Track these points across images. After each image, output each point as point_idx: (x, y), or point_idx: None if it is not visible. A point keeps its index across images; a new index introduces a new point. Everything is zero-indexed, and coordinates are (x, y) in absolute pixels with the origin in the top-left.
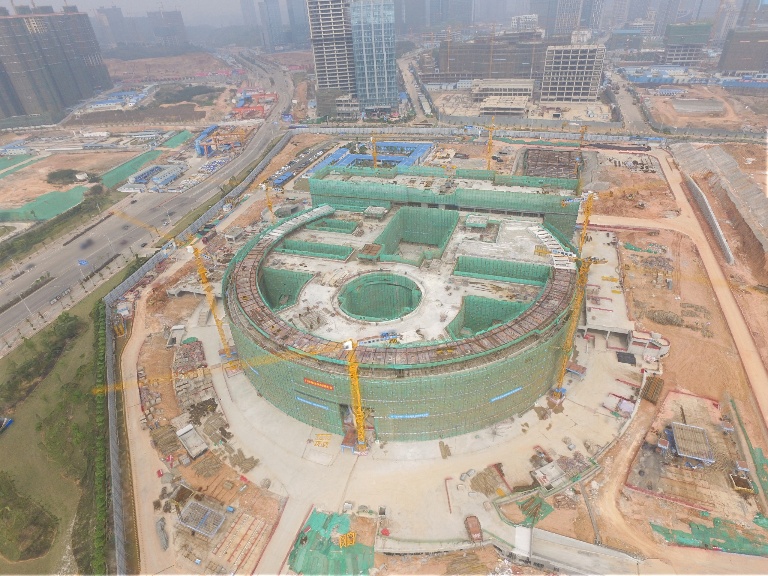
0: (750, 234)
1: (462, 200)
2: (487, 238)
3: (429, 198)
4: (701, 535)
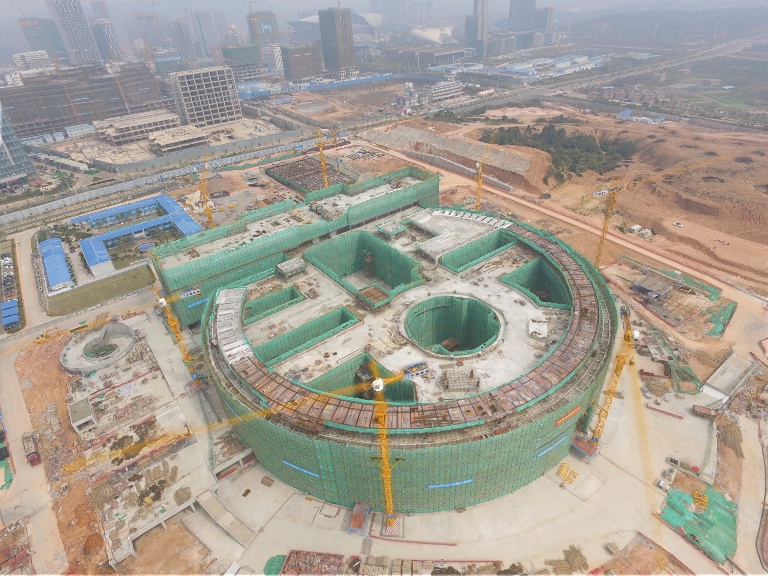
0: (499, 170)
1: (355, 217)
2: (416, 237)
3: (322, 229)
4: (717, 322)
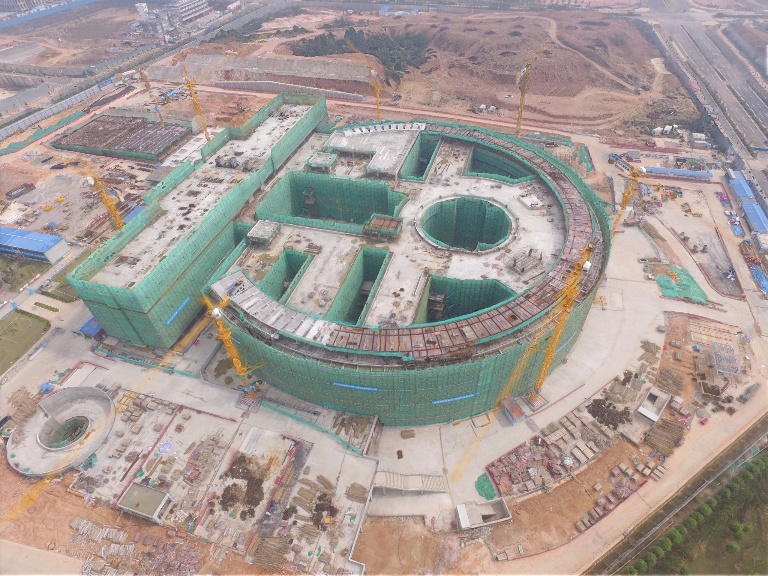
0: (338, 82)
1: (278, 160)
2: None
3: (256, 182)
4: None
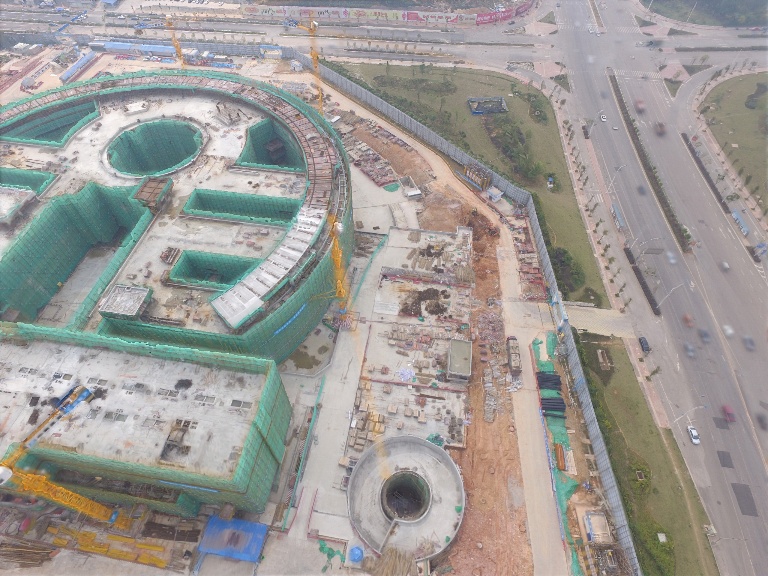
0: None
1: None
2: None
3: None
4: None
